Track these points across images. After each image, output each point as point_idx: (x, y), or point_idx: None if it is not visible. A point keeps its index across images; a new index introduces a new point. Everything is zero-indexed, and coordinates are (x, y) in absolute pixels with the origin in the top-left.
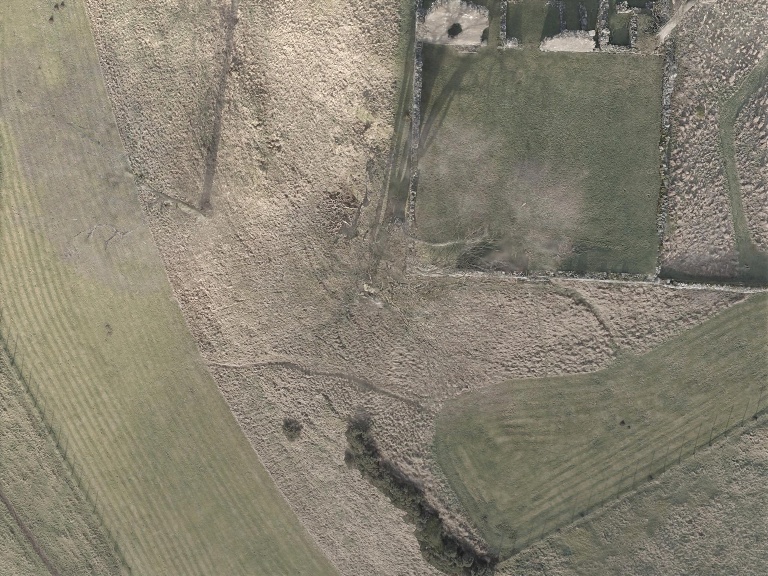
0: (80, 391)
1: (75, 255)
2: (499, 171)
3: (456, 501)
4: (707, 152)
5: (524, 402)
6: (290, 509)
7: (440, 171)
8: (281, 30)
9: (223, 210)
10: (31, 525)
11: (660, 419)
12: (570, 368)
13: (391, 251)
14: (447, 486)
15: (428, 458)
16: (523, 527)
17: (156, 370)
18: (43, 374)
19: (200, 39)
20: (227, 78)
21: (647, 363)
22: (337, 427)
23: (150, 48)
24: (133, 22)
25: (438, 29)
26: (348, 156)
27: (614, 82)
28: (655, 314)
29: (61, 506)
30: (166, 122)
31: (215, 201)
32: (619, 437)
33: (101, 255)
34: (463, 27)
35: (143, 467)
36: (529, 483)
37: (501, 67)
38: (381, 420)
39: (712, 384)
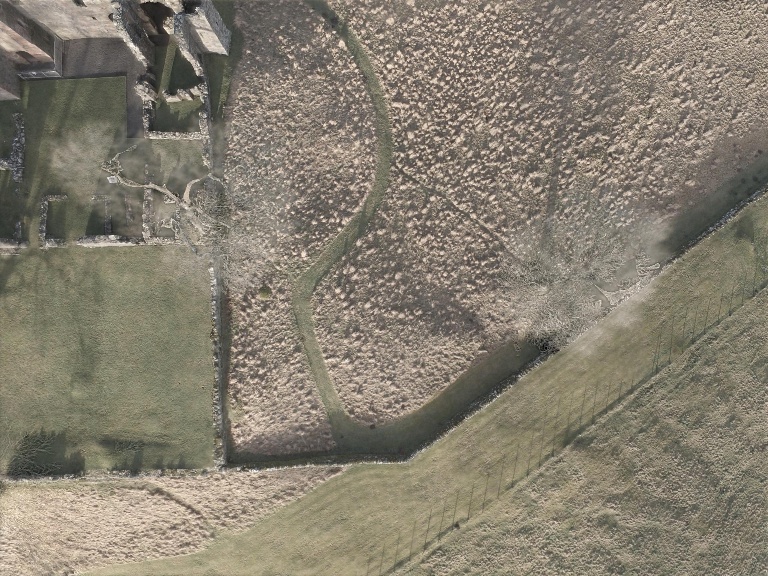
0: None
1: None
2: (52, 370)
3: None
4: (278, 331)
5: None
6: None
7: None
8: None
9: None
10: None
11: None
12: (168, 551)
13: None
14: None
15: None
16: None
17: None
18: None
19: None
20: None
21: (247, 542)
22: None
23: None
24: None
25: None
26: None
27: (164, 273)
28: (245, 495)
29: None
30: None
31: None
32: None
33: None
34: None
35: None
36: None
37: (47, 266)
38: None
39: (318, 558)
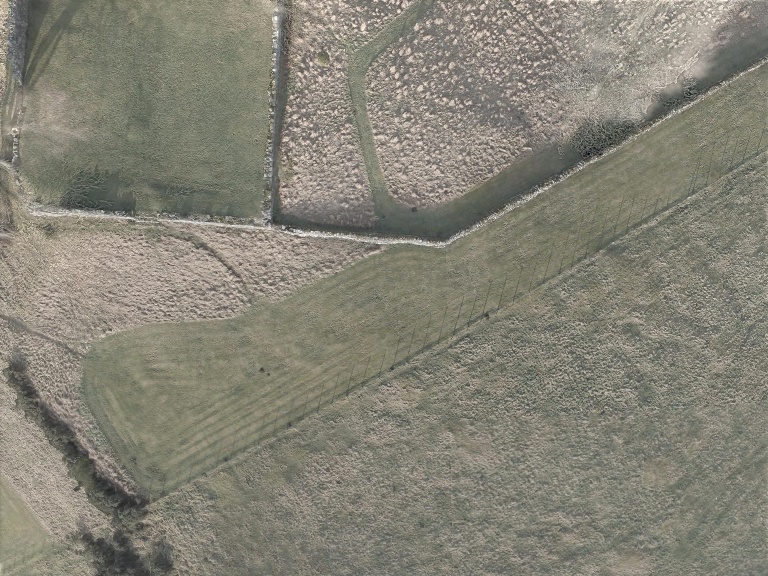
0: None
1: None
2: (110, 111)
3: (104, 442)
4: (332, 100)
5: (165, 346)
6: None
7: (47, 109)
8: None
9: None
10: None
11: (298, 367)
12: (206, 313)
13: (15, 190)
14: (95, 427)
15: (76, 399)
16: (172, 470)
17: None
18: None
19: None
20: None
21: (282, 311)
22: (4, 368)
23: None
24: None
25: None
26: None
27: (226, 25)
28: (285, 262)
29: None
30: None
31: None
32: (259, 384)
33: None
34: None
35: None
36: (175, 427)
37: (112, 7)
38: (35, 361)
39: (350, 334)
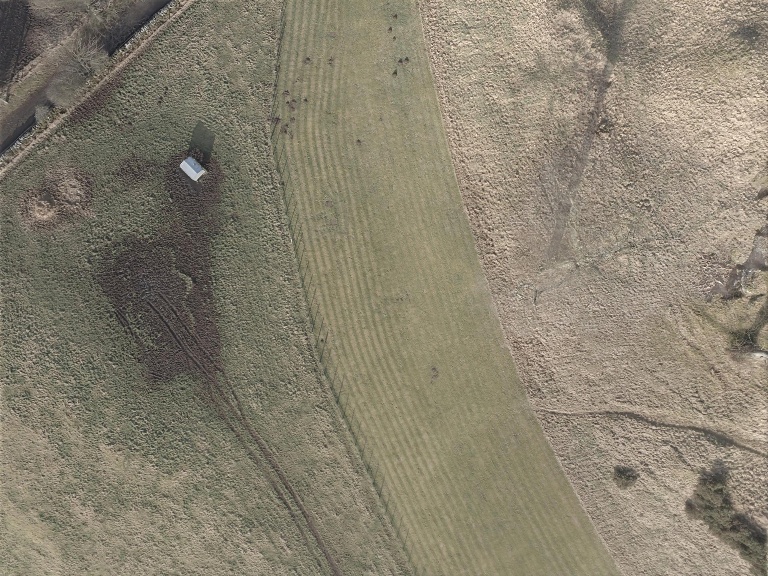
0: (401, 431)
1: (406, 300)
2: None
3: None
4: None
5: None
6: (608, 554)
7: None
8: (663, 96)
9: None
10: (338, 559)
11: None
12: None
13: None
14: None
15: None
16: None
17: (480, 413)
18: (366, 413)
19: (561, 99)
20: (594, 138)
21: None
22: (685, 478)
23: (498, 104)
24: (482, 79)
25: None
26: (735, 220)
27: None
28: None
29: (371, 542)
30: (512, 176)
31: (564, 254)
32: None
33: (433, 300)
34: None
35: (457, 507)
36: None
37: None
38: (740, 475)
39: None
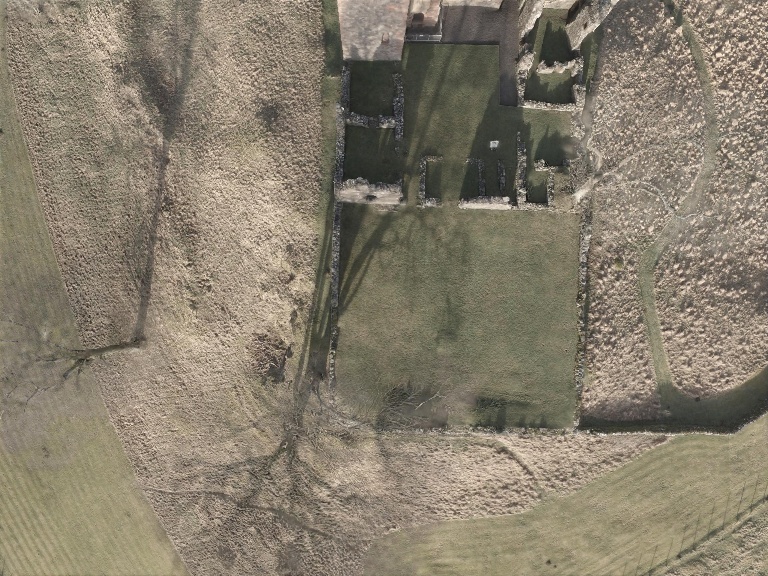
0: (17, 513)
1: (12, 379)
2: (419, 326)
3: None
4: (626, 302)
5: (451, 542)
6: None
7: (360, 328)
8: (210, 175)
9: (157, 342)
10: None
11: (585, 558)
12: (495, 510)
13: (315, 401)
14: None
15: None
16: None
17: (93, 493)
18: None
19: (134, 174)
20: (159, 216)
21: (571, 505)
22: (269, 560)
23: (86, 178)
24: (70, 152)
25: (354, 197)
26: (274, 303)
27: (532, 238)
28: (578, 458)
29: None
30: (102, 251)
31: (149, 332)
32: None
33: (38, 379)
34: (378, 197)
35: None
36: None
37: (421, 224)
38: (311, 557)
39: (636, 524)
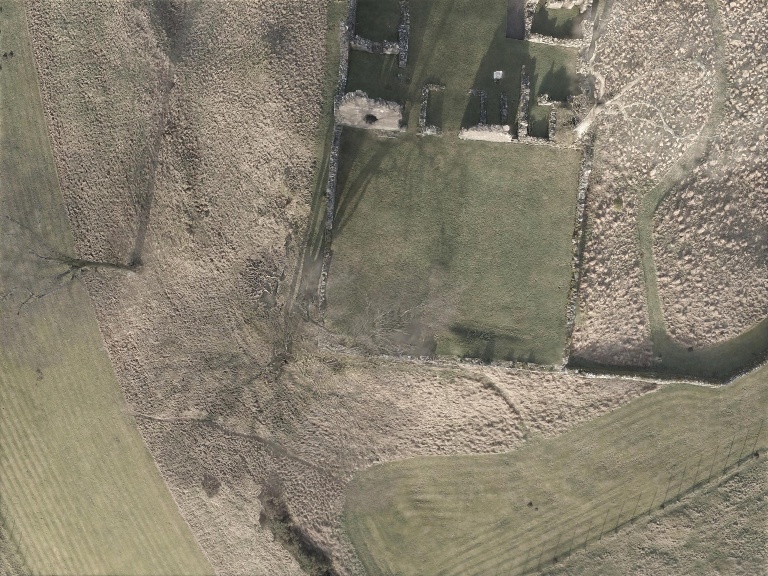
0: (9, 433)
1: (10, 299)
2: (413, 255)
3: (363, 571)
4: (623, 244)
5: (433, 478)
6: (208, 562)
7: (353, 252)
8: (213, 99)
9: (153, 267)
10: None
11: (568, 503)
12: (480, 448)
13: (305, 325)
14: (354, 556)
15: (337, 527)
16: None
17: (84, 417)
18: None
19: (139, 99)
20: (161, 140)
21: (557, 447)
22: (252, 489)
23: (92, 102)
24: (77, 76)
25: (353, 117)
26: (270, 228)
27: (531, 173)
28: (565, 400)
29: None
30: (104, 176)
31: (146, 257)
32: (526, 518)
33: None
34: (377, 117)
35: (67, 511)
36: (436, 558)
37: (420, 153)
38: (293, 486)
39: (621, 471)
